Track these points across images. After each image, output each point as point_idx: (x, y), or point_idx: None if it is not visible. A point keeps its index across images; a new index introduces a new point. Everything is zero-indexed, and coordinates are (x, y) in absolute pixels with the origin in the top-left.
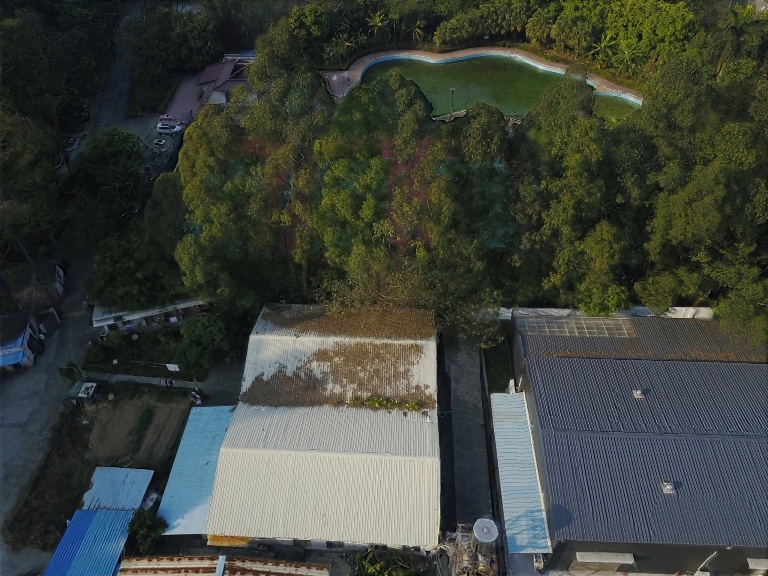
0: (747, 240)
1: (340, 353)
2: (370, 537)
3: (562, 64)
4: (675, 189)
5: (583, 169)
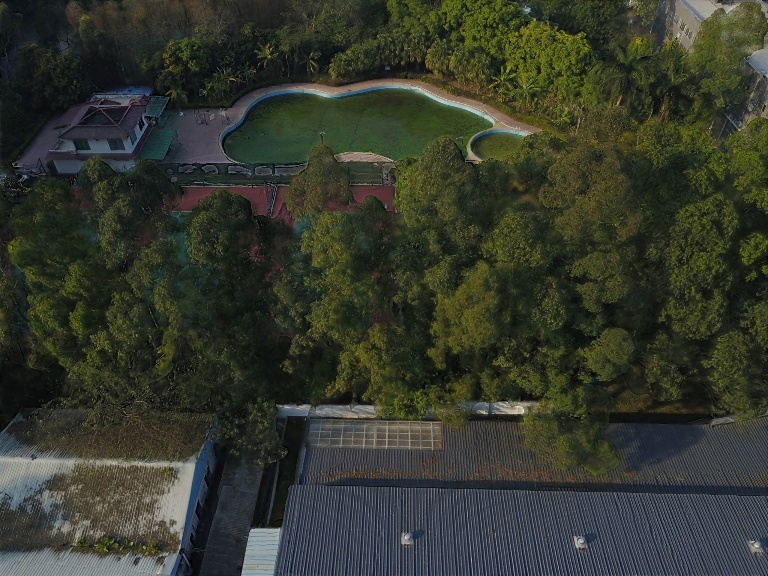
0: (551, 343)
1: (79, 479)
2: None
3: (463, 97)
4: (446, 292)
5: (346, 266)
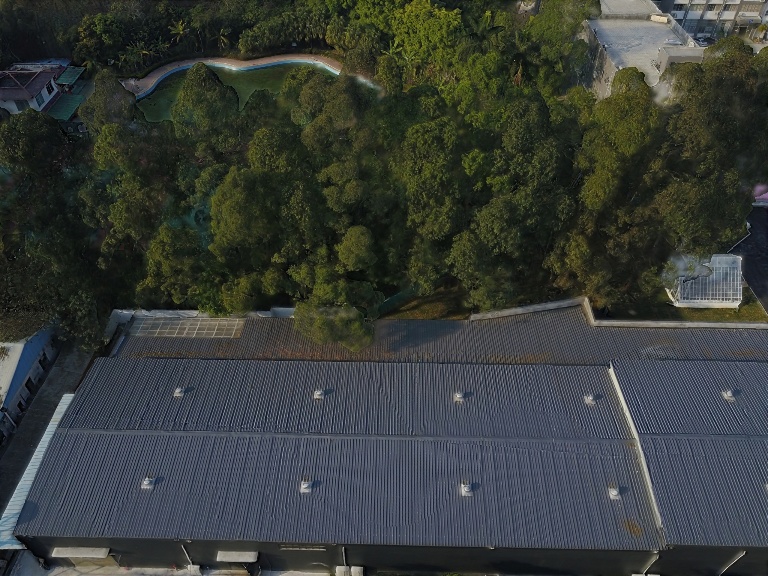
0: (313, 241)
1: None
2: None
3: None
4: (210, 192)
5: (136, 173)
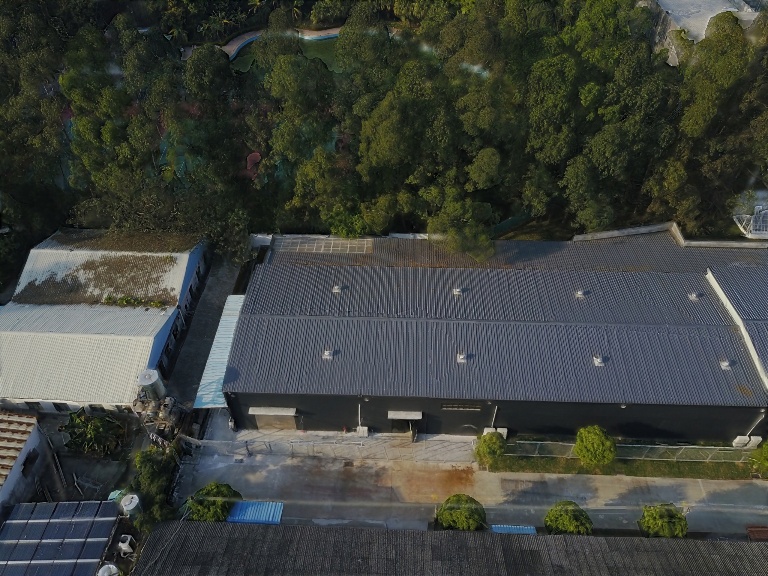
0: (446, 164)
1: (105, 263)
2: (82, 396)
3: None
4: (365, 116)
5: (297, 101)
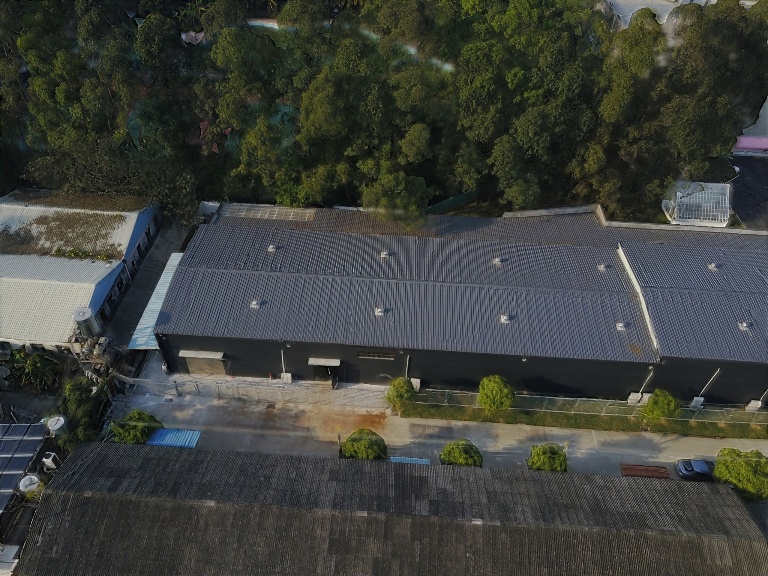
0: (381, 138)
1: (57, 219)
2: (23, 335)
3: None
4: (304, 88)
5: (242, 73)
